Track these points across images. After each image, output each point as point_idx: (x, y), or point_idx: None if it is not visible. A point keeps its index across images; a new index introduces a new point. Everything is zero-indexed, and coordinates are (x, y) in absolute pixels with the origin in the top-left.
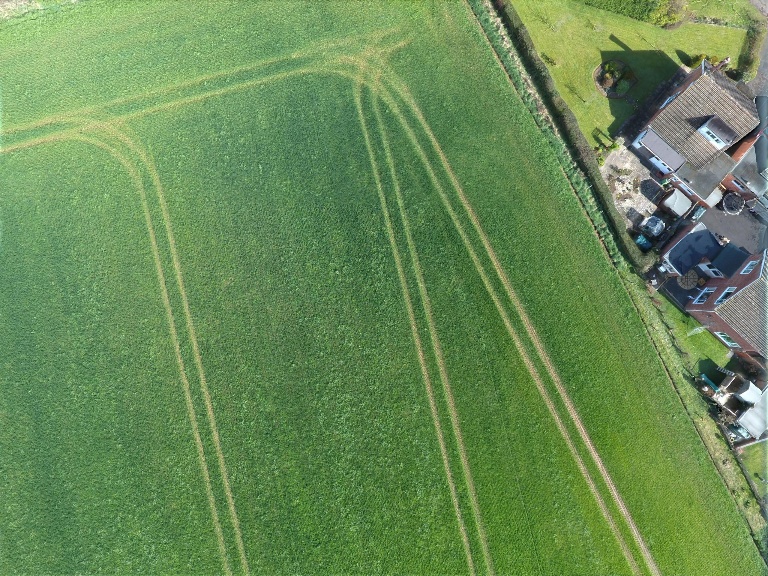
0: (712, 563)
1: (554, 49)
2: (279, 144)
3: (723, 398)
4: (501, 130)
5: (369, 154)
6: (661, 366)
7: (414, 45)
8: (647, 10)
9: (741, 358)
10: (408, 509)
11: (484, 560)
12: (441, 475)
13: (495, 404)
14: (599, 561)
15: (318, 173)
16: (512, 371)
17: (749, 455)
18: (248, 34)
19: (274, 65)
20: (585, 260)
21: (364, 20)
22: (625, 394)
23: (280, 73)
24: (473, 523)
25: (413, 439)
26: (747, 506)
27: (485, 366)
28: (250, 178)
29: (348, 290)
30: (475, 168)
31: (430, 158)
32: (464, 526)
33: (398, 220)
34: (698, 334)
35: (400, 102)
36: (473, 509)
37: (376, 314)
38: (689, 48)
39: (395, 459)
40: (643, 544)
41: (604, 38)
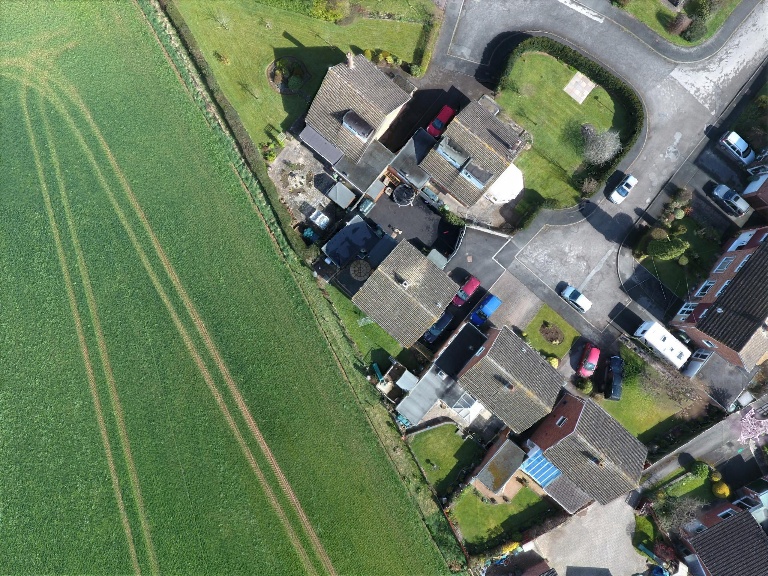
0: (383, 548)
1: (226, 47)
2: None
3: (387, 386)
4: (171, 128)
5: (33, 155)
6: (332, 356)
7: (82, 46)
8: (306, 7)
9: (413, 347)
10: (68, 502)
11: (147, 550)
12: (103, 468)
13: (160, 397)
14: (266, 549)
15: None
16: (178, 365)
17: (421, 442)
18: None
19: None
20: (255, 254)
21: (29, 23)
22: (295, 385)
23: None
24: (135, 515)
25: (74, 434)
26: (417, 492)
27: (150, 360)
28: None
29: (9, 289)
30: (143, 166)
31: (96, 157)
32: (127, 518)
33: (62, 219)
34: (370, 324)
35: (67, 103)
36: (136, 501)
37: (38, 312)
38: (363, 43)
39: (55, 454)
40: (312, 531)
41: (277, 35)
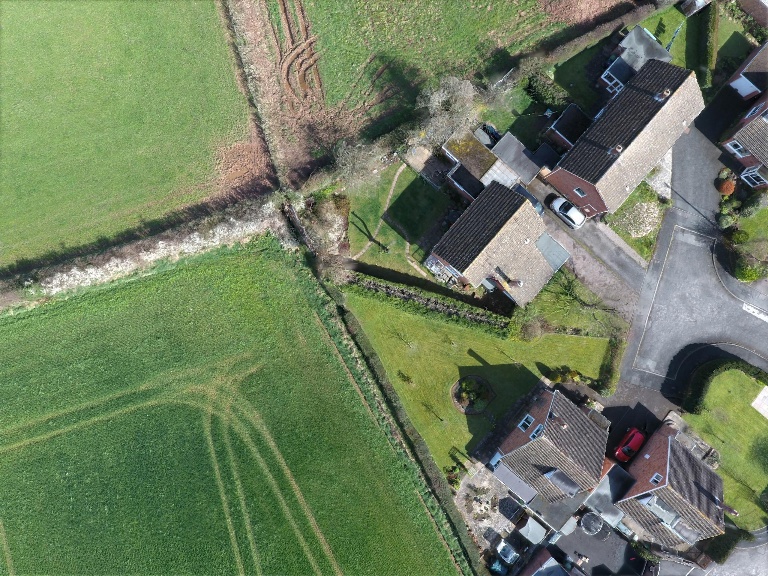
0: None
1: (411, 366)
2: (126, 483)
3: None
4: (355, 454)
5: (219, 488)
6: None
7: (266, 370)
8: None
9: None
10: None
11: None
12: None
13: None
14: None
15: (166, 511)
16: None
17: None
18: (95, 369)
19: (122, 400)
20: None
21: (215, 348)
22: None
23: (128, 407)
24: None
25: None
26: None
27: None
28: (96, 520)
29: None
30: (328, 495)
31: (281, 489)
32: None
33: (248, 556)
34: None
35: (252, 430)
36: None
37: None
38: (549, 360)
39: None
40: None
41: (462, 353)
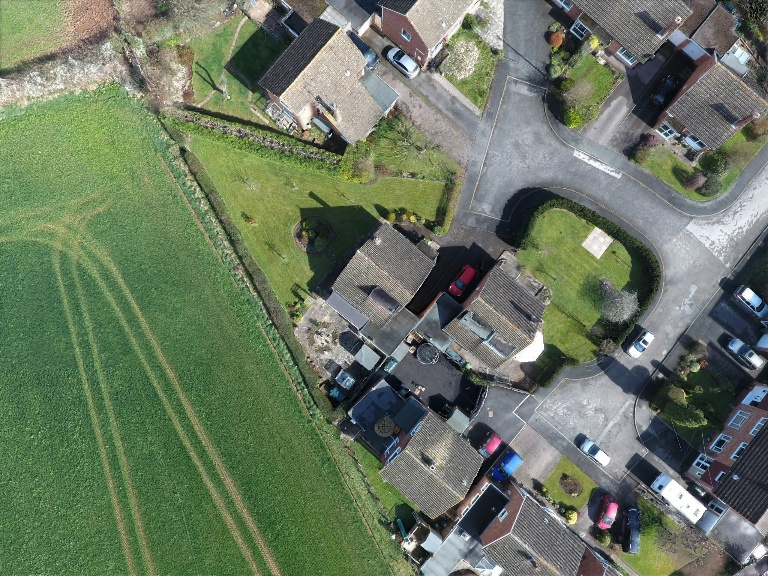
0: None
1: (254, 208)
2: None
3: (411, 545)
4: (200, 289)
5: (67, 319)
6: (357, 513)
7: (113, 210)
8: (332, 174)
9: None
10: None
11: None
12: None
13: (191, 557)
14: None
15: (15, 341)
16: (208, 524)
17: None
18: None
19: None
20: (282, 413)
21: (62, 189)
22: (321, 541)
23: None
24: None
25: None
26: None
27: (181, 521)
28: None
29: (44, 453)
30: (173, 328)
31: (128, 321)
32: None
33: (95, 383)
34: None
35: (99, 266)
36: None
37: (71, 475)
38: (387, 202)
39: None
40: None
41: (303, 195)
